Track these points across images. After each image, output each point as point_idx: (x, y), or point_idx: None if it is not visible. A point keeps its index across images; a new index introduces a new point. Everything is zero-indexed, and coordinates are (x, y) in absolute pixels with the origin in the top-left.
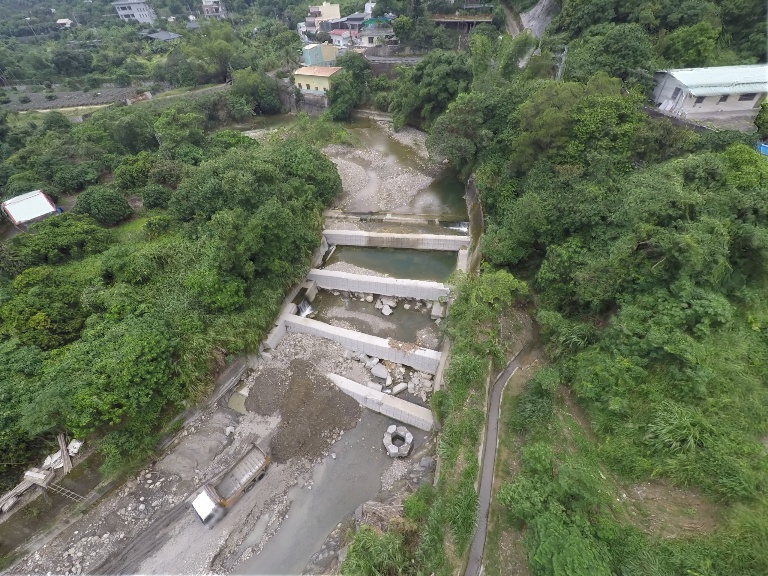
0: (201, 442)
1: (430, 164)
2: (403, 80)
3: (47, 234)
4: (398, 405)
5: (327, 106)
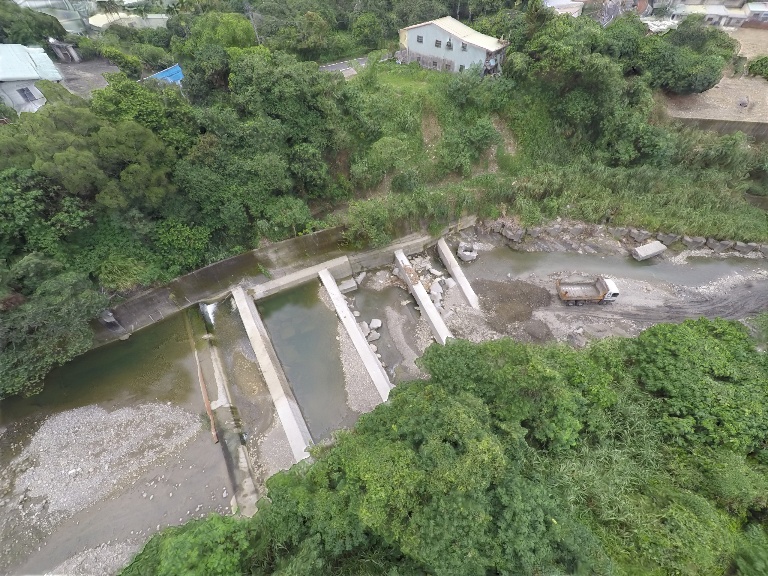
0: None
1: None
2: None
3: None
4: (452, 257)
5: None
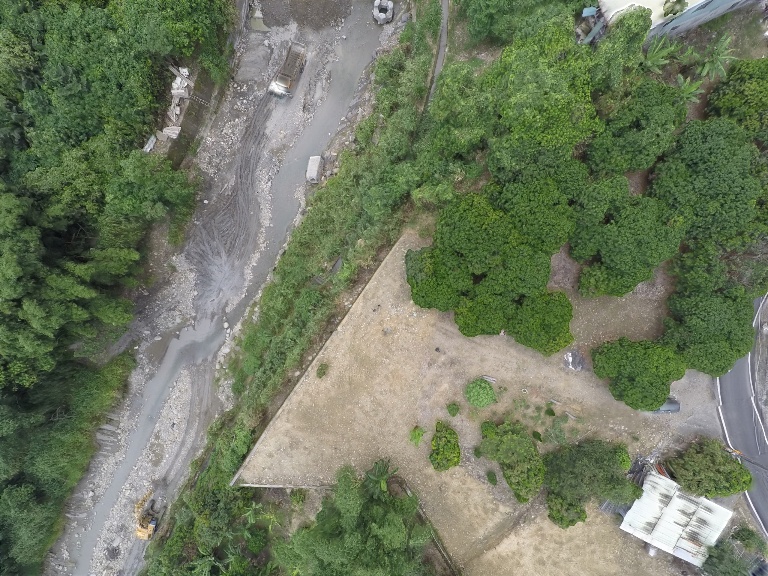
0: (254, 55)
1: None
2: None
3: None
4: None
5: None
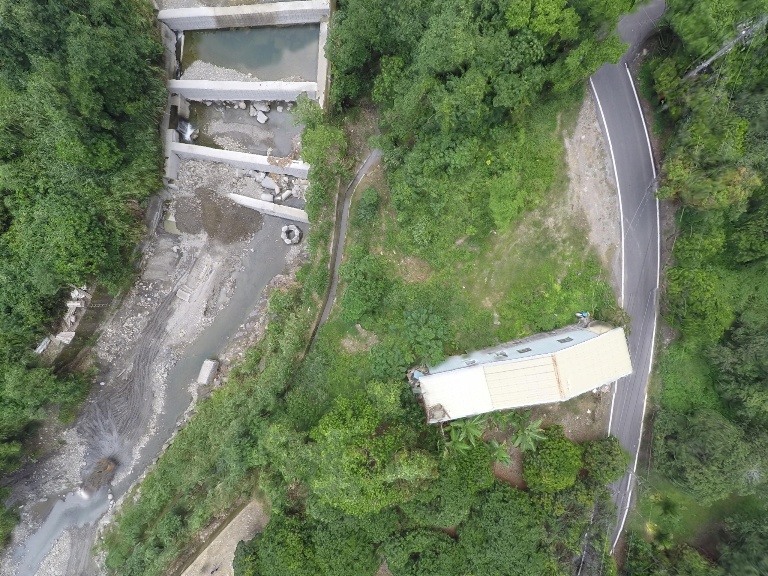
0: (161, 260)
1: None
2: None
3: None
4: (286, 212)
5: None
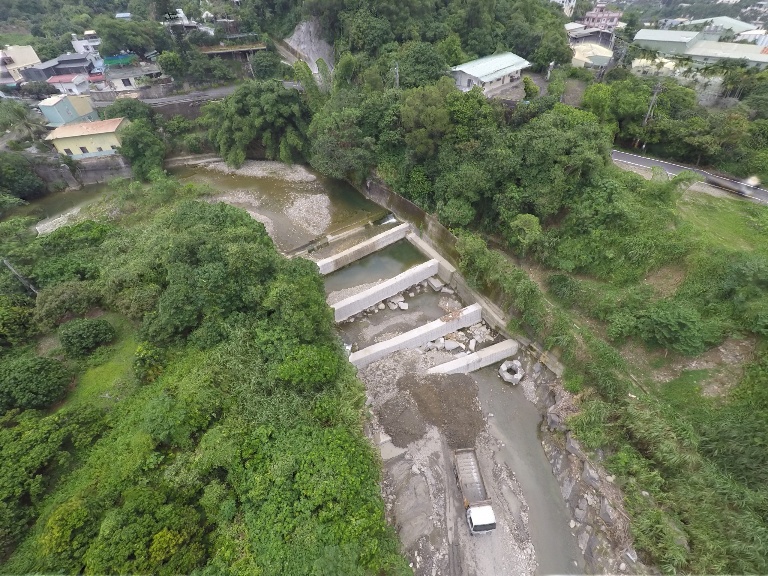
0: (411, 496)
1: (306, 184)
2: (219, 116)
3: (2, 465)
4: (491, 351)
5: (125, 166)
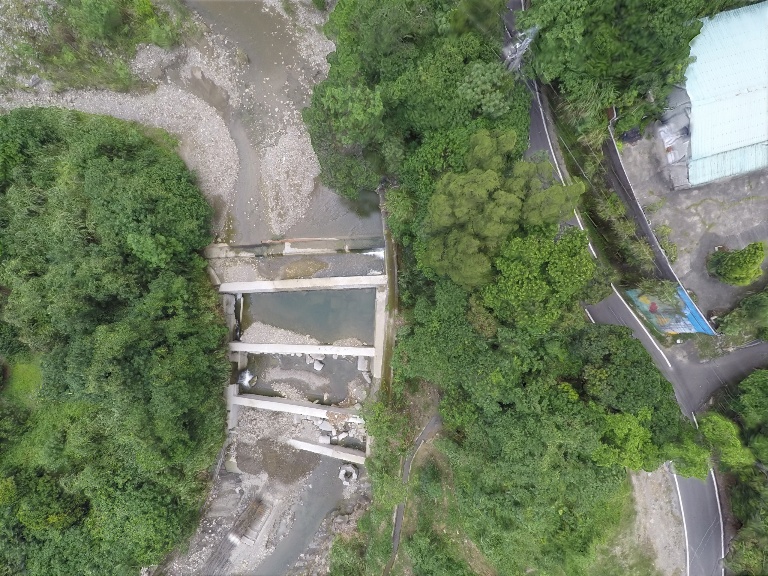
0: (224, 502)
1: None
2: None
3: None
4: (344, 458)
5: None
